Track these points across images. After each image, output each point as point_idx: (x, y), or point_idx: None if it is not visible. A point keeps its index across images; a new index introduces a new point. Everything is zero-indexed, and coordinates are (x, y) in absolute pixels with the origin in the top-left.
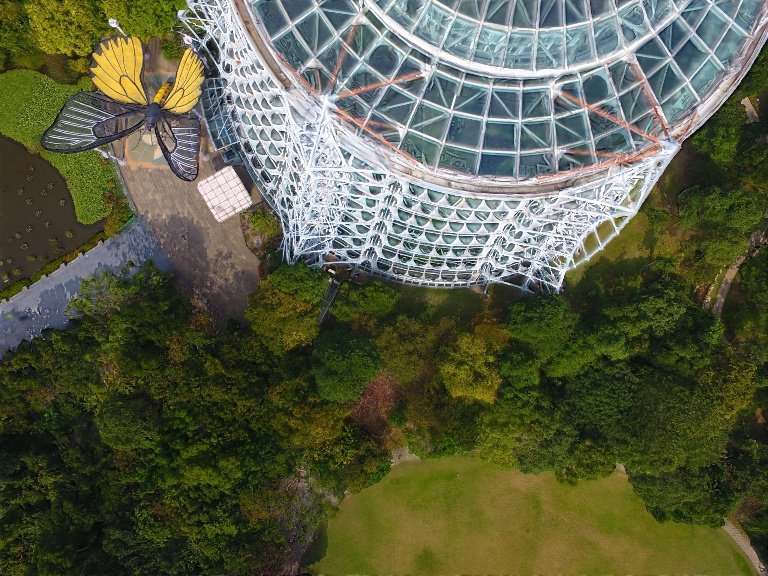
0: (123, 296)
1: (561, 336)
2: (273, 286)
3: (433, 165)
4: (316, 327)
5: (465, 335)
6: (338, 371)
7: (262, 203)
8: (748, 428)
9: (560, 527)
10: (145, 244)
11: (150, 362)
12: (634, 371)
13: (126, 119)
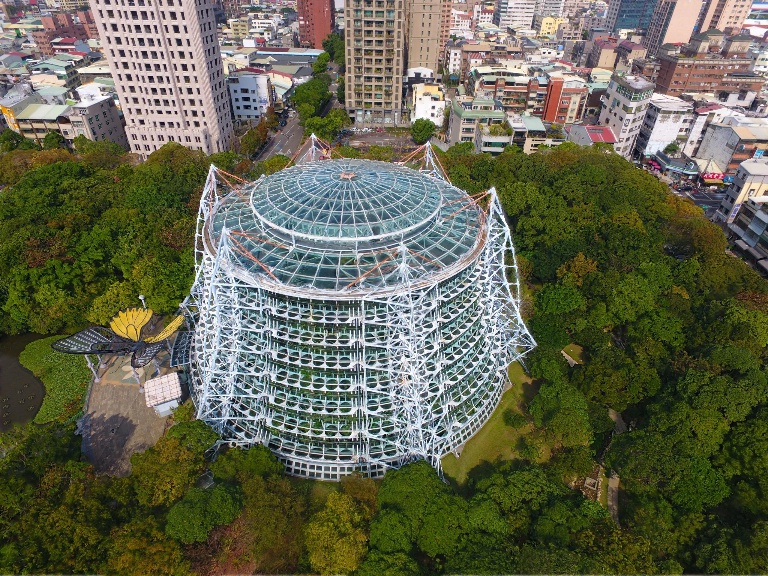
0: None
1: (427, 493)
2: None
3: (286, 283)
4: None
5: (333, 492)
6: (194, 500)
7: (190, 408)
8: None
9: None
10: None
11: (19, 480)
12: (519, 549)
13: (118, 357)
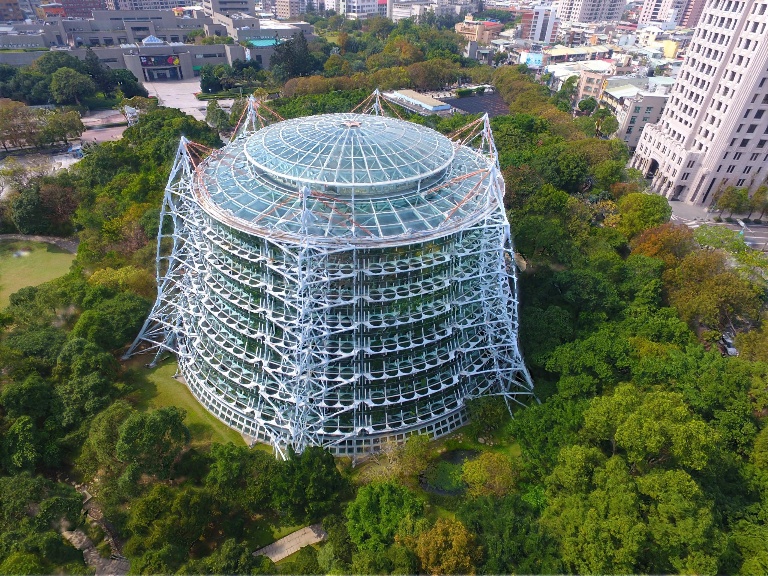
0: None
1: None
2: None
3: None
4: None
5: None
6: None
7: None
8: None
9: None
10: None
11: None
12: None
13: None
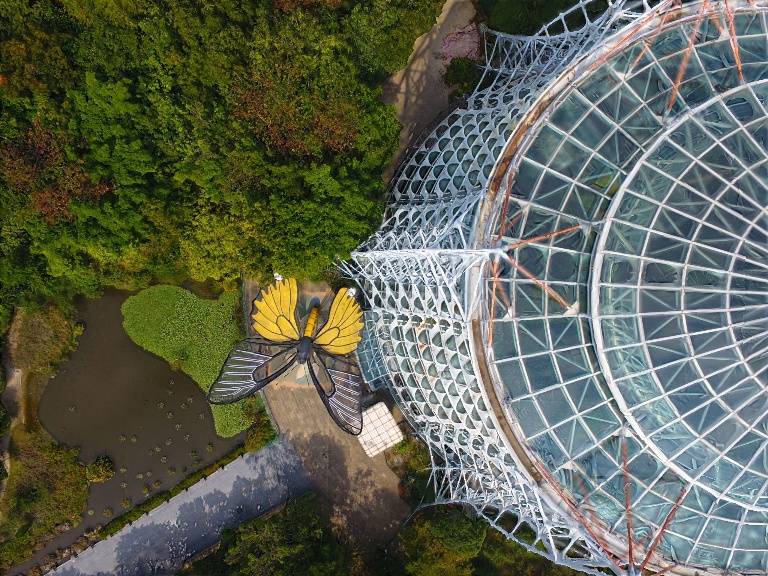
0: (289, 554)
1: None
2: (432, 535)
3: (683, 560)
4: None
5: None
6: None
7: (403, 423)
8: None
9: None
10: (285, 461)
11: None
12: None
13: None
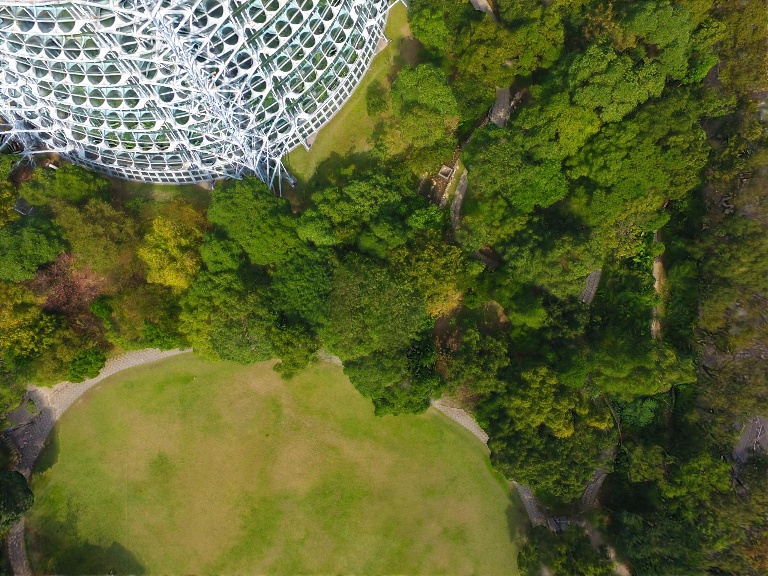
0: None
1: (252, 216)
2: None
3: None
4: (14, 214)
5: None
6: (4, 246)
7: None
8: (491, 327)
9: (301, 431)
10: None
11: None
12: (343, 258)
13: None
